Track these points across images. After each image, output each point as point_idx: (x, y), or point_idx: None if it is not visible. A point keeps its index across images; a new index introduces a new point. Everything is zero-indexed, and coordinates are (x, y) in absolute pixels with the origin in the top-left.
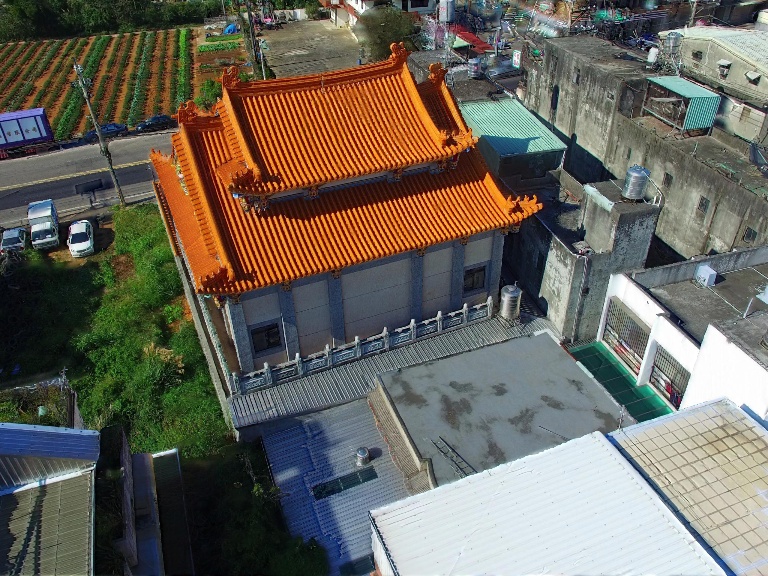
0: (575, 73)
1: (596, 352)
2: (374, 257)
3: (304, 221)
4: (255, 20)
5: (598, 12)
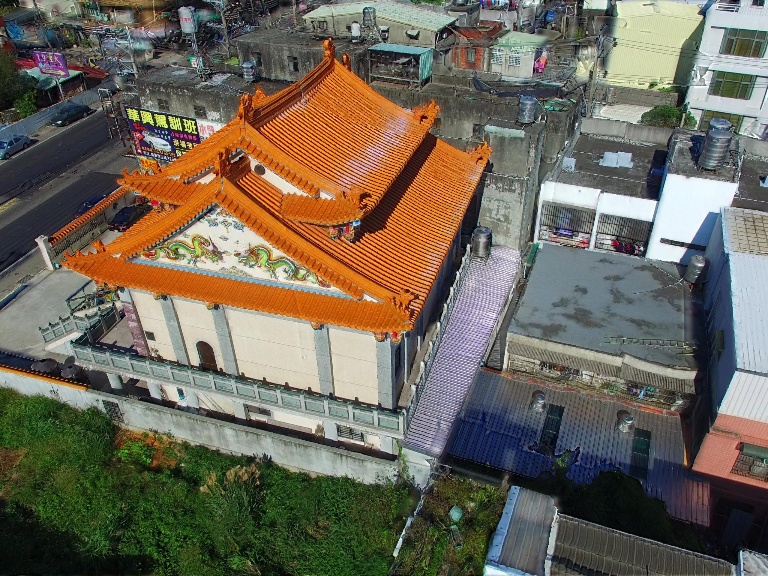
0: (290, 62)
1: None
2: (454, 234)
3: (383, 230)
4: None
5: (244, 8)
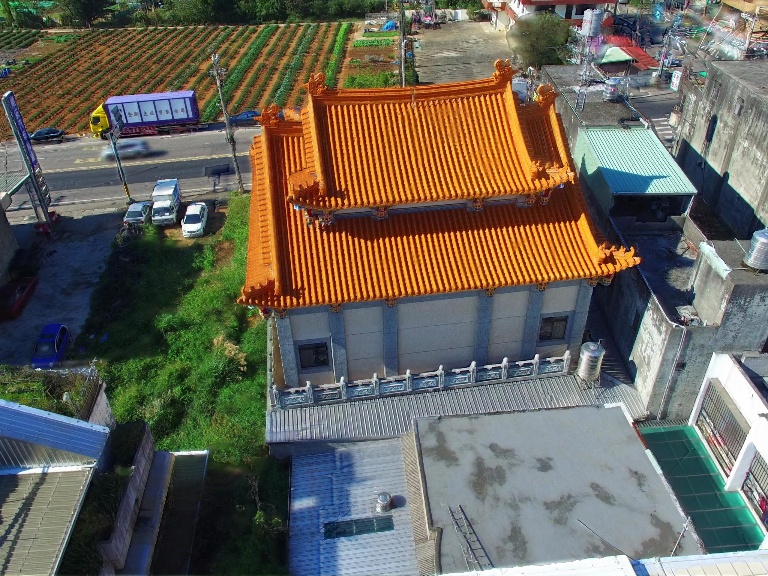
0: (738, 103)
1: (684, 438)
2: (432, 291)
3: (367, 241)
4: (414, 18)
5: None
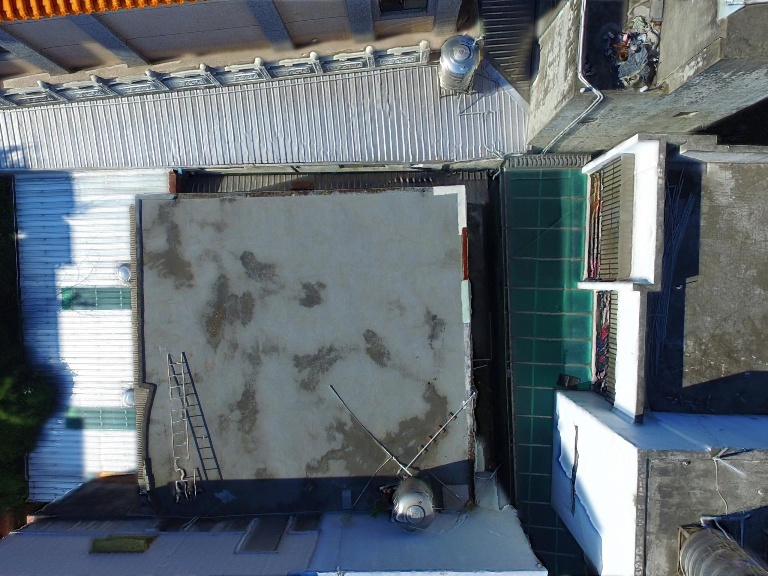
0: None
1: (564, 193)
2: (95, 7)
3: None
4: None
5: None
